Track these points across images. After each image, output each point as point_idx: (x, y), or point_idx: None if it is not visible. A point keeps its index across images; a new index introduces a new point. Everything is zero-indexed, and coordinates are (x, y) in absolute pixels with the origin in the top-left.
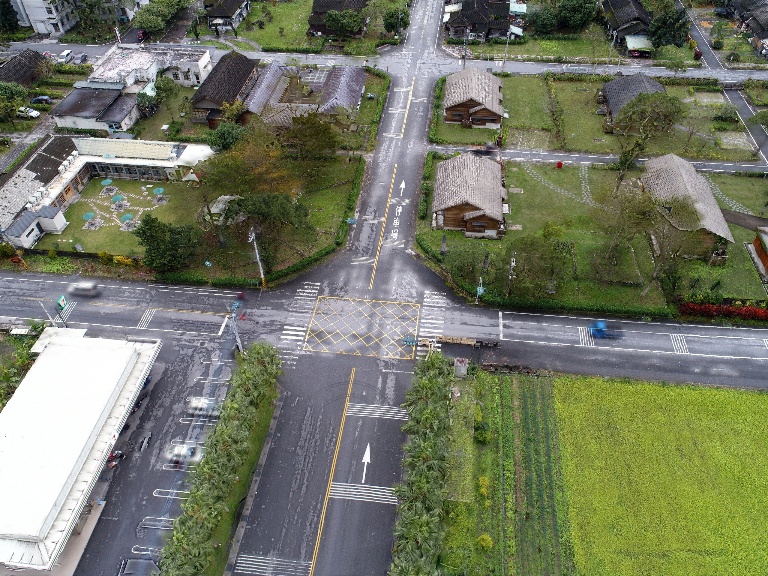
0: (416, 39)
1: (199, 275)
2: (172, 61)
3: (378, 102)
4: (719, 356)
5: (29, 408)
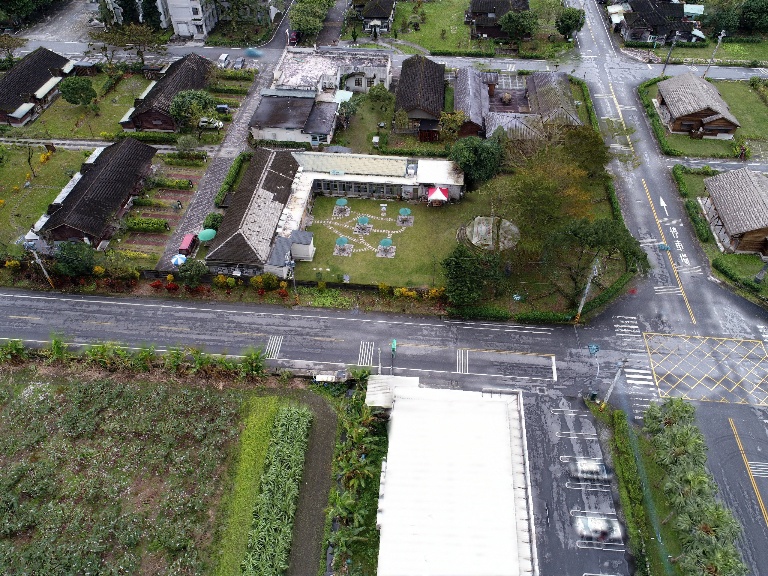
0: (589, 42)
1: (497, 309)
2: (356, 66)
3: (589, 110)
4: None
5: (417, 478)
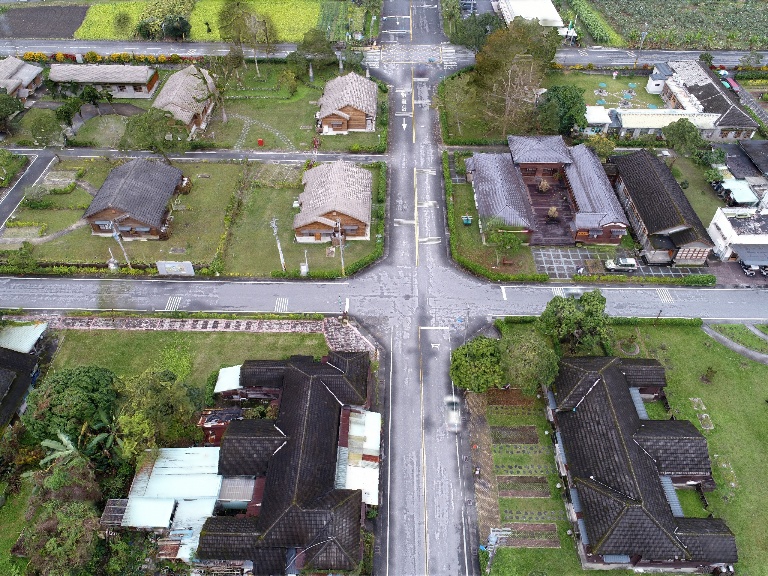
0: (432, 375)
1: None
2: None
3: None
4: (223, 50)
5: None
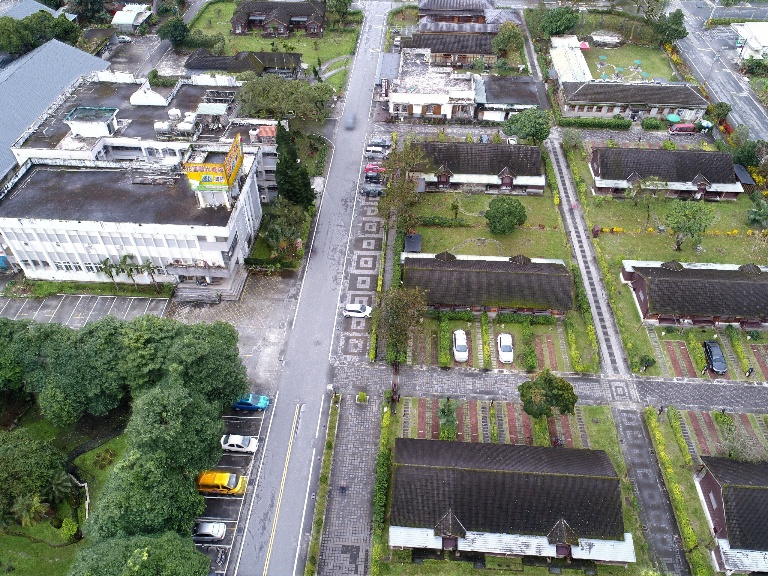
0: None
1: None
2: None
3: None
4: None
5: None
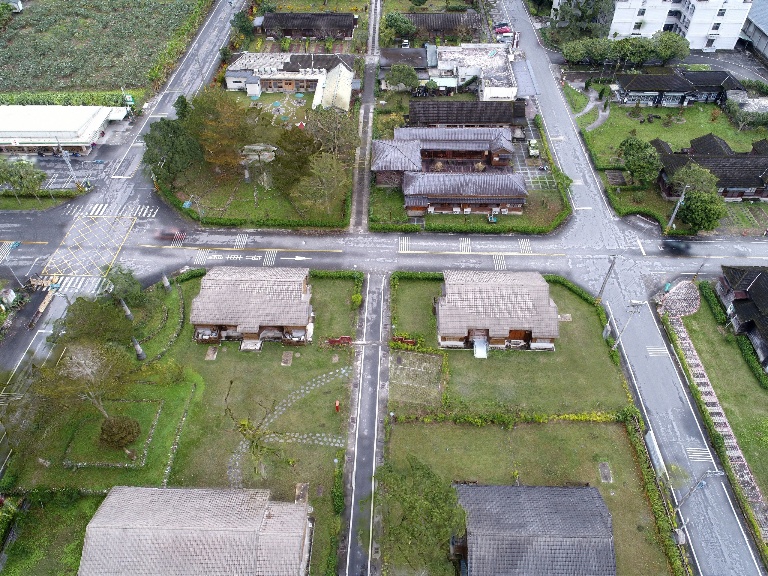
0: (693, 251)
1: None
2: None
3: None
4: None
5: None
